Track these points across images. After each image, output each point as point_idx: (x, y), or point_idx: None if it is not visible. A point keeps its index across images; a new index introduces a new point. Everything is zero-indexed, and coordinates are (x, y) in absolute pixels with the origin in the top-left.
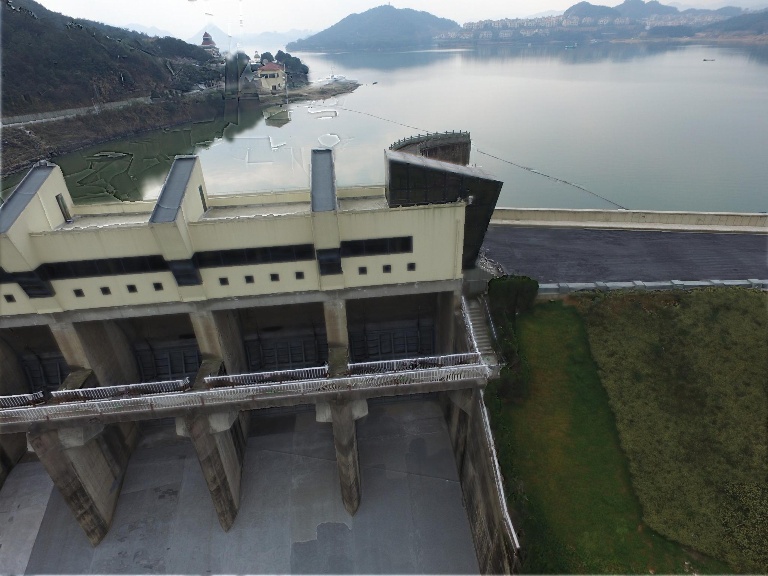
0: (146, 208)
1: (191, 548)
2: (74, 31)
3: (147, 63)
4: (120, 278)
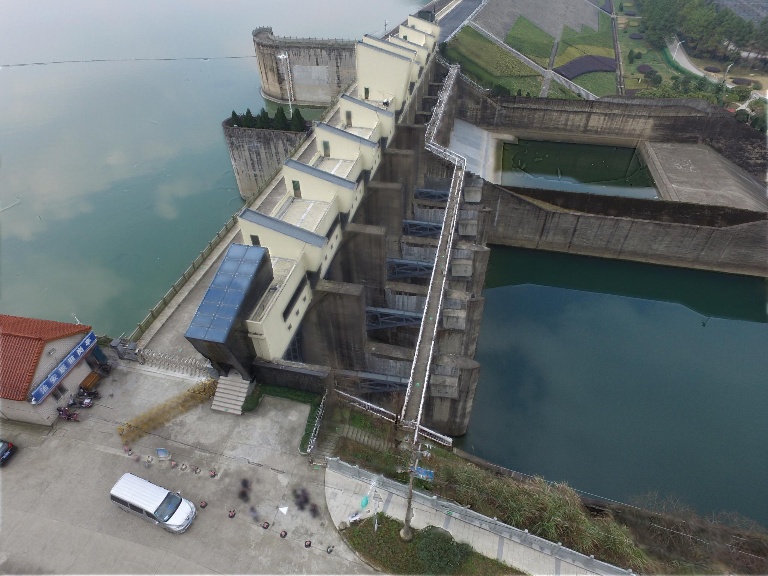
0: None
1: None
2: None
3: None
4: None
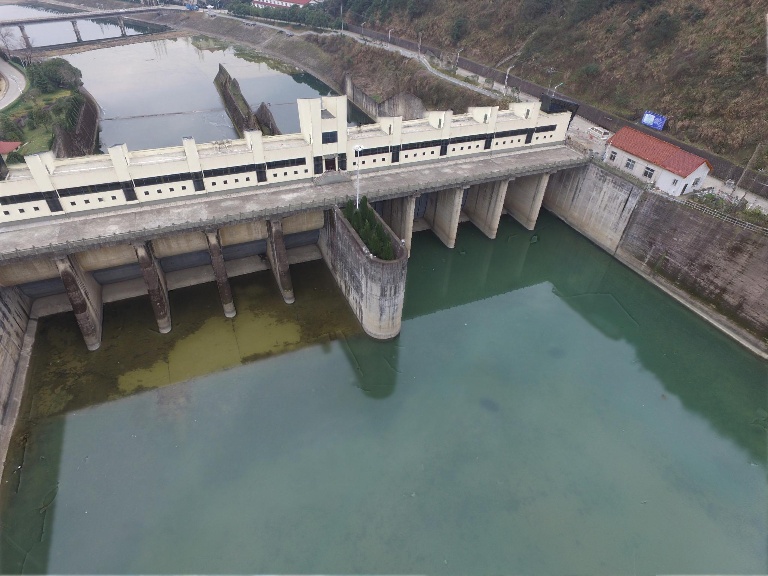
0: (151, 167)
1: None
2: None
3: None
4: None
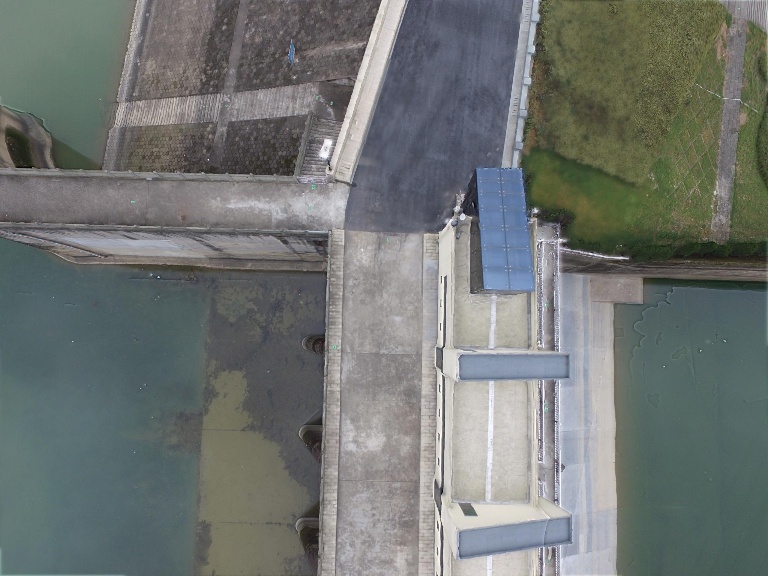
0: None
1: None
2: None
3: None
4: None
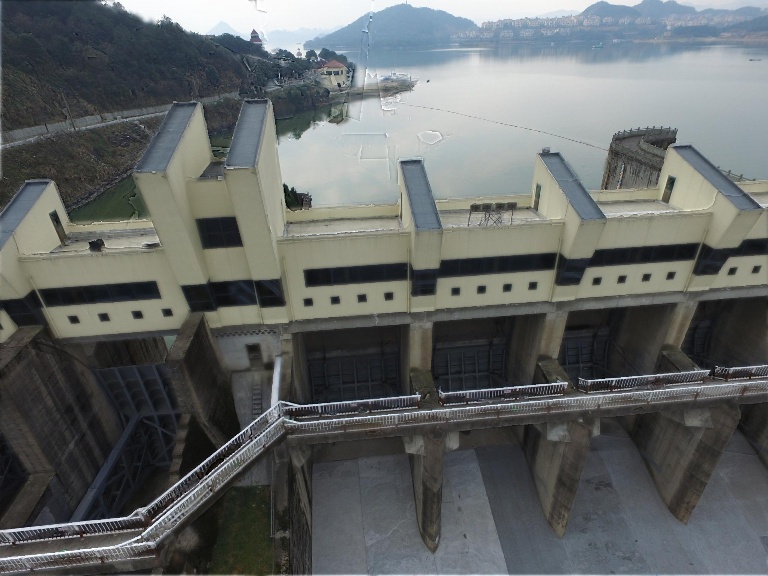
0: (620, 197)
1: (659, 541)
2: (165, 27)
3: (230, 59)
4: (642, 266)
